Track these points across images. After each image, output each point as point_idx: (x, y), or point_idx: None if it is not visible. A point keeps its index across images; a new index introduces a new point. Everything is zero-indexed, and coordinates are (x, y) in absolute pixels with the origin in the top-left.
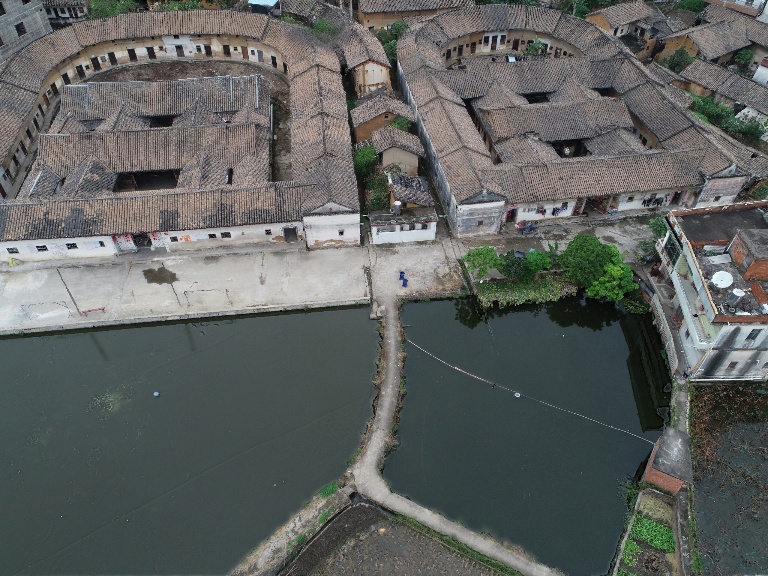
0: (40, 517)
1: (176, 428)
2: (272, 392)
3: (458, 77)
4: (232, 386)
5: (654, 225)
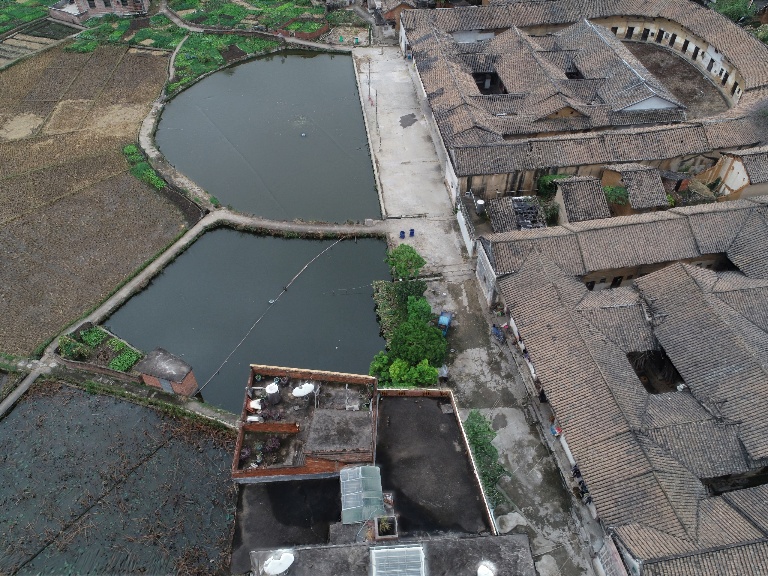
0: (232, 114)
1: (277, 145)
2: (300, 179)
3: (765, 240)
4: (306, 161)
5: (470, 415)
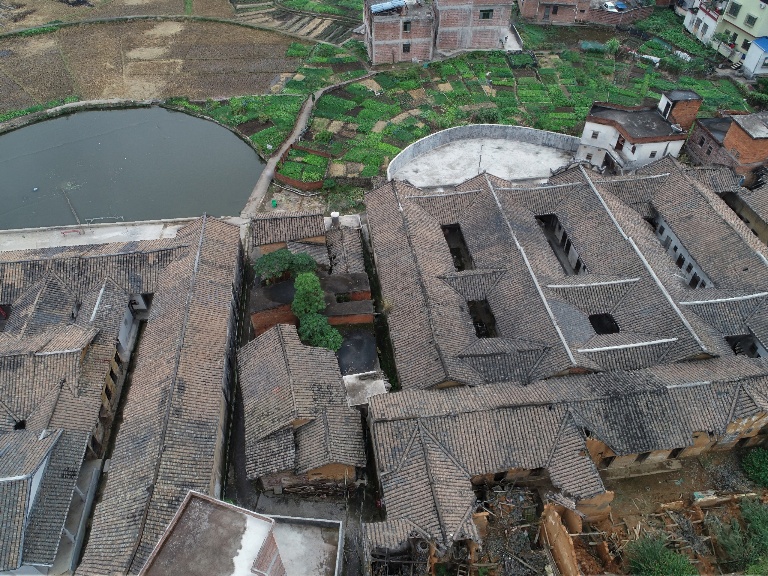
0: (111, 143)
1: (28, 174)
2: None
3: None
4: None
5: None
